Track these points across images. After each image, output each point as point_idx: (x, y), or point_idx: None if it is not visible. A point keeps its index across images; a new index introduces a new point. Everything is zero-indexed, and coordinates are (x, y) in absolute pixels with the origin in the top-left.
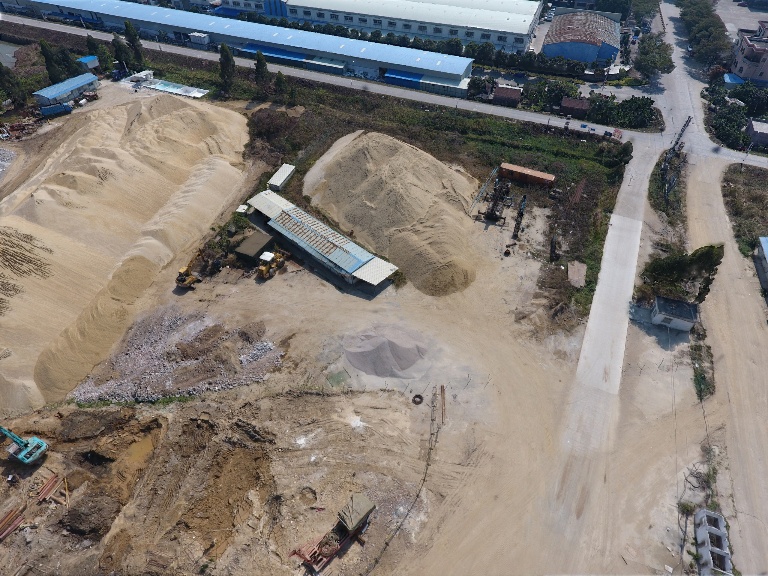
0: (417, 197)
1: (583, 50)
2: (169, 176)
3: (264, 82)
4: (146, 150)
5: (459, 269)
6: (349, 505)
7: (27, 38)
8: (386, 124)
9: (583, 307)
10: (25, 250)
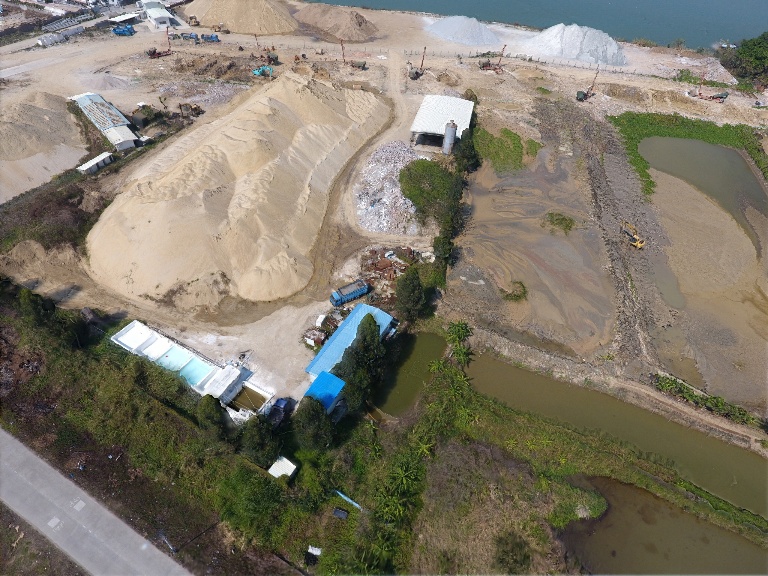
0: None
1: None
2: None
3: None
4: None
5: None
6: (152, 49)
7: None
8: None
9: None
10: None
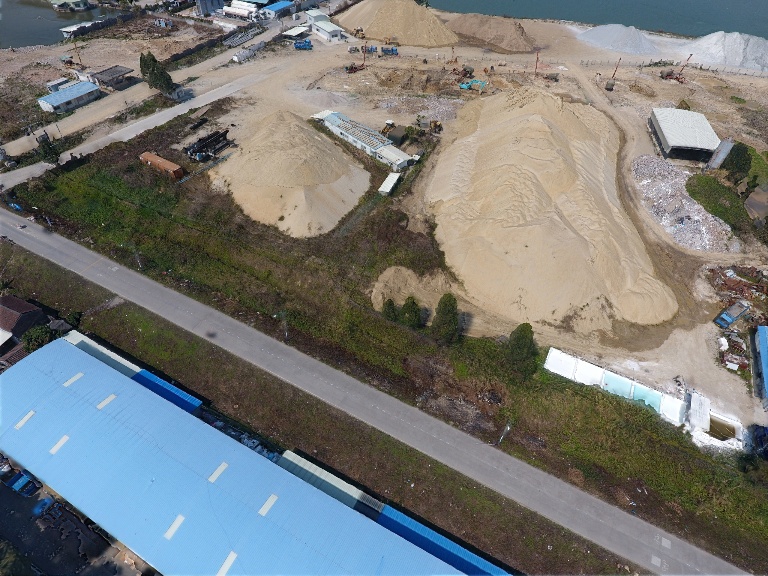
0: None
1: None
2: None
3: None
4: None
5: None
6: (351, 64)
7: None
8: (263, 250)
9: None
10: None
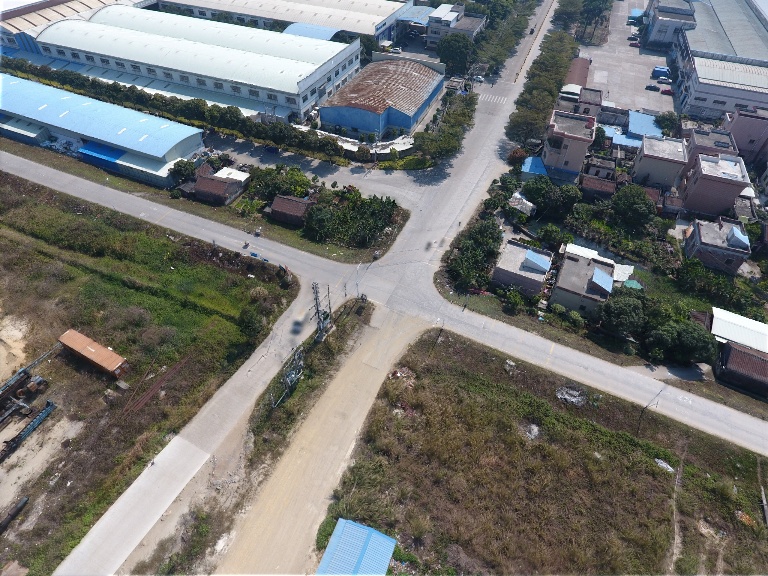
0: None
1: (363, 117)
2: None
3: None
4: None
5: None
6: None
7: None
8: None
9: None
10: None
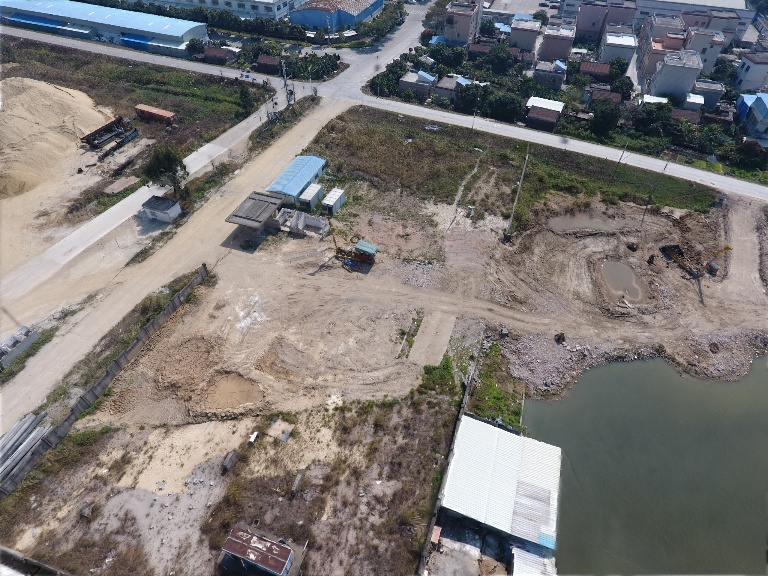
0: (16, 127)
1: (320, 17)
2: None
3: None
4: None
5: (15, 180)
6: None
7: None
8: (78, 77)
9: (104, 208)
10: None
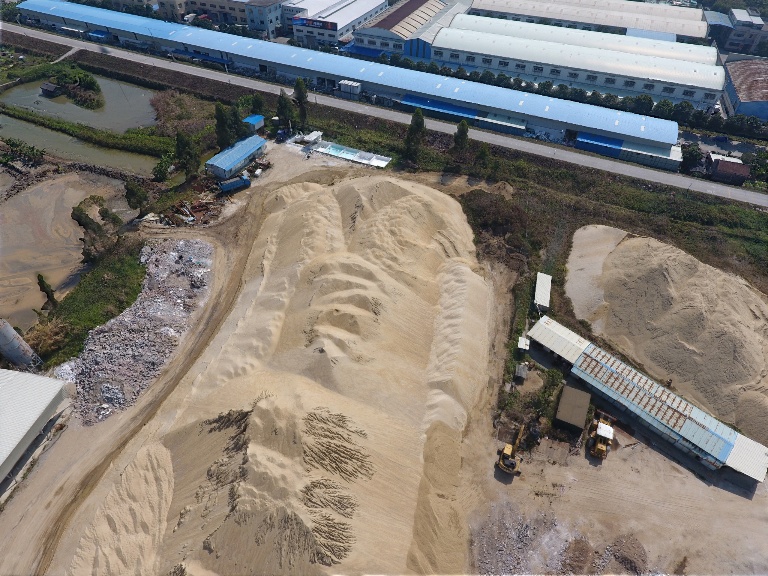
0: (750, 340)
1: None
2: (424, 295)
3: (461, 153)
4: (395, 262)
5: None
6: None
7: (159, 82)
8: (618, 211)
9: None
10: (344, 439)
